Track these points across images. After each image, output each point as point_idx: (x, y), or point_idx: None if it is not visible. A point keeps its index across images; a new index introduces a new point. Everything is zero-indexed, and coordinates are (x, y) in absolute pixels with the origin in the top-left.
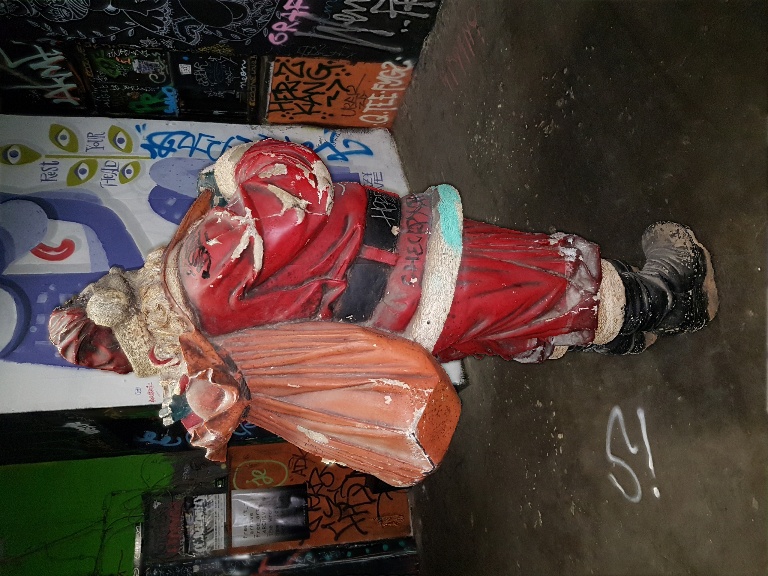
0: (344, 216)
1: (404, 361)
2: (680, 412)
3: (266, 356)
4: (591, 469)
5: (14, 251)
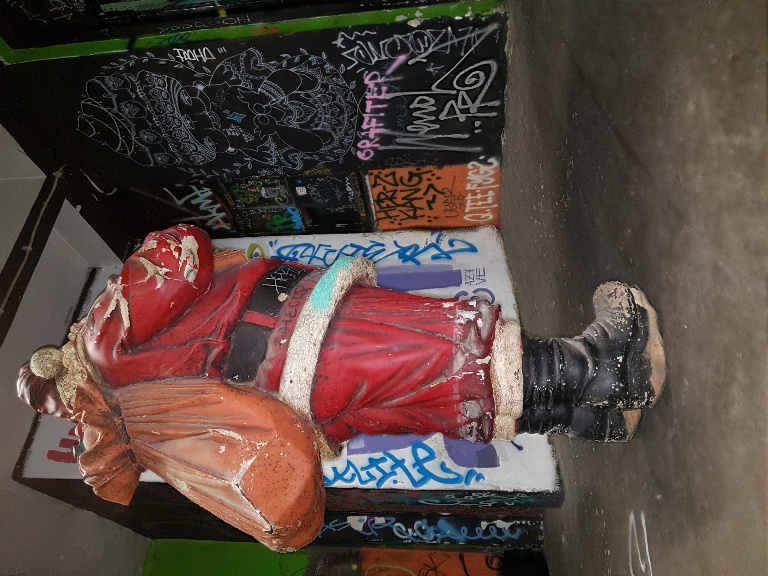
0: (232, 285)
1: (246, 414)
2: (662, 515)
3: (142, 406)
4: None
5: None
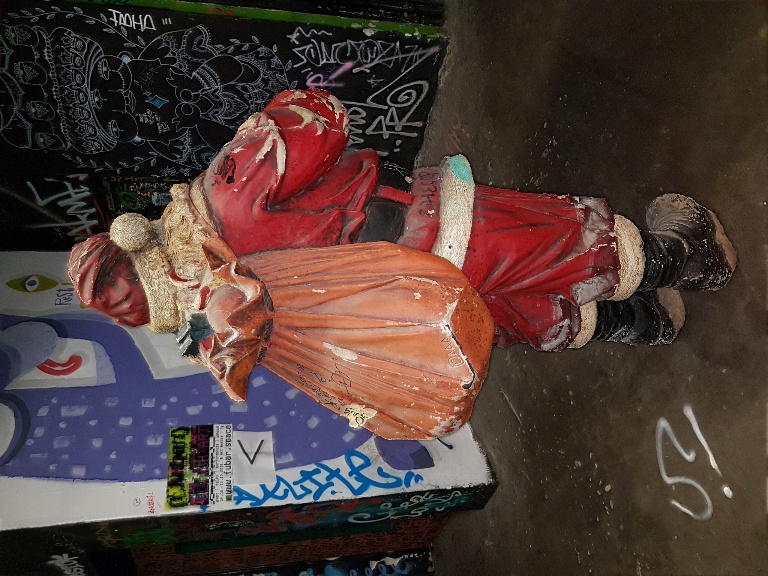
0: (359, 162)
1: (430, 265)
2: (729, 386)
3: (289, 267)
4: (649, 508)
5: (20, 366)
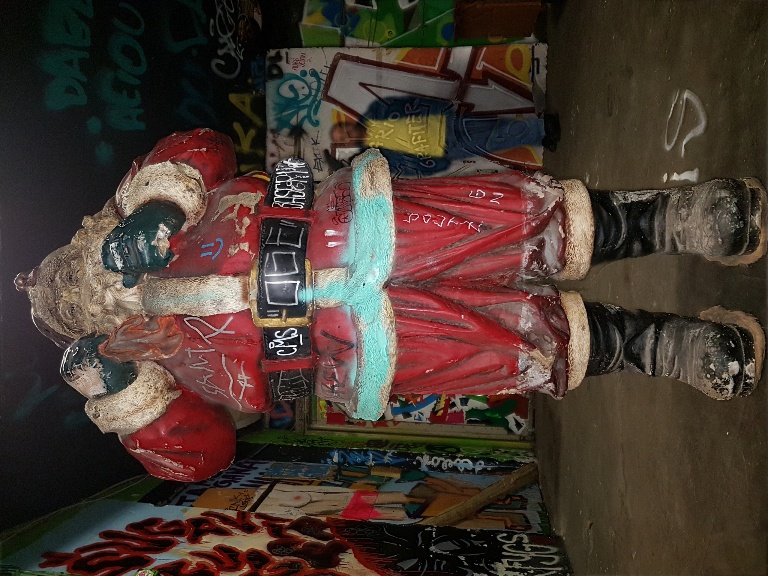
0: None
1: None
2: None
3: None
4: None
5: None
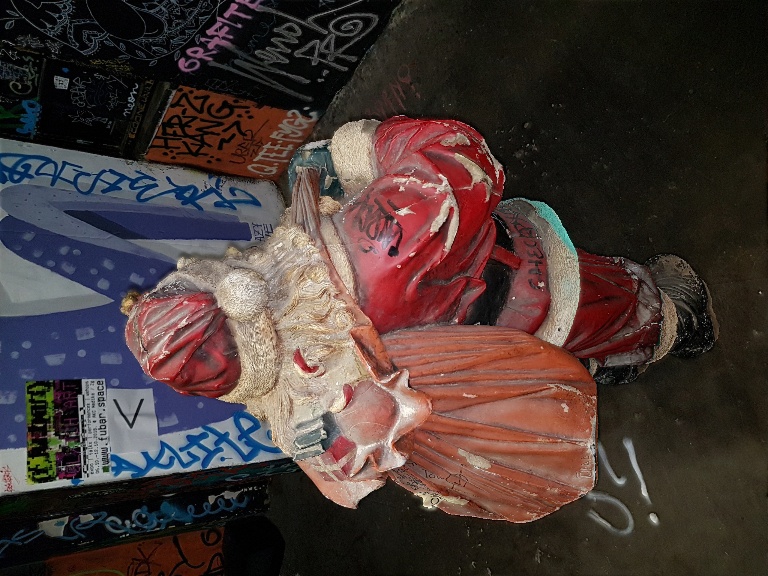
0: None
1: (566, 366)
2: (678, 434)
3: (434, 361)
4: (563, 510)
5: None
